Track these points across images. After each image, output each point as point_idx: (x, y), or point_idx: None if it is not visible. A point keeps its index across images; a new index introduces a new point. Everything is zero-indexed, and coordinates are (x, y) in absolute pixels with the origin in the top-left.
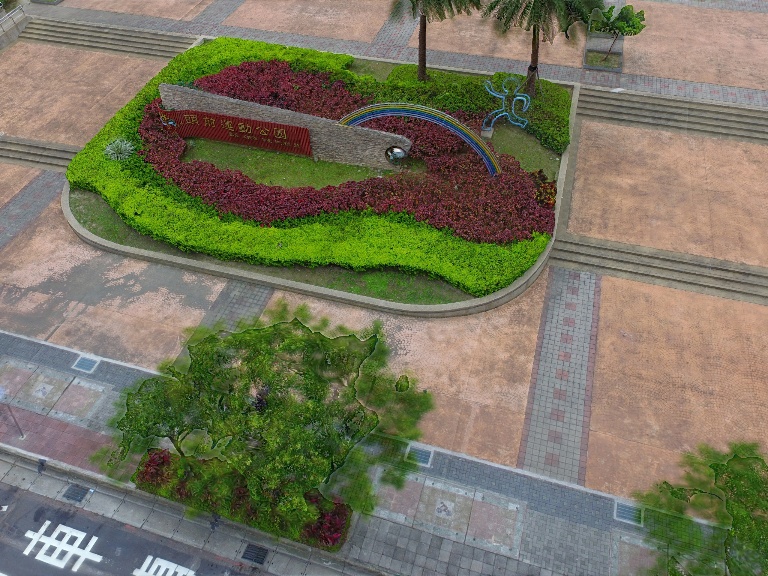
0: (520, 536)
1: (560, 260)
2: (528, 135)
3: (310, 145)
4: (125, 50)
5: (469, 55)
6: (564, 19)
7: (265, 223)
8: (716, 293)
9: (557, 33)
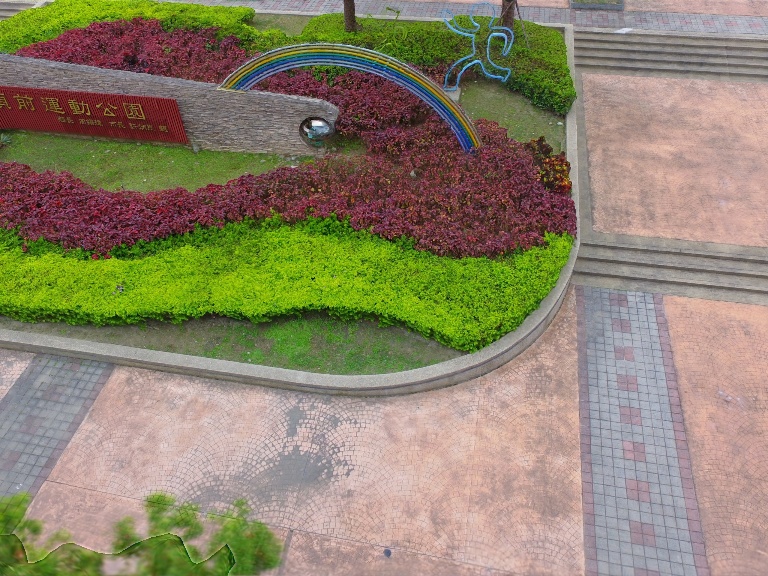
0: None
1: (590, 275)
2: (511, 94)
3: (183, 127)
4: None
5: (415, 2)
6: None
7: (99, 252)
8: None
9: None
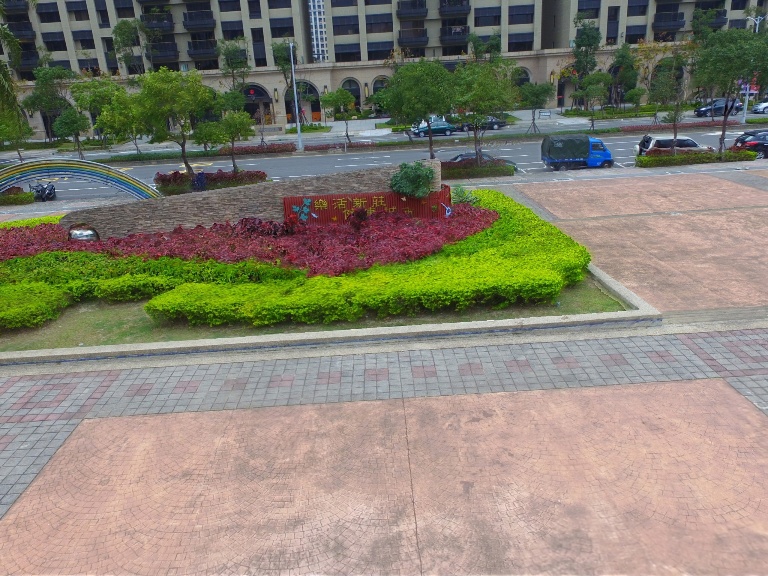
0: (68, 204)
1: None
2: None
3: None
4: None
5: None
6: None
7: None
8: None
9: None
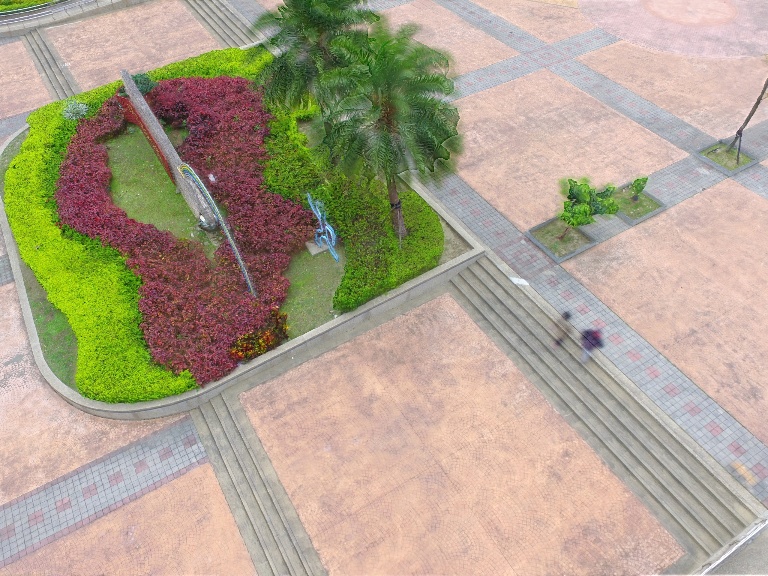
0: None
1: (203, 416)
2: None
3: (173, 175)
4: (216, 30)
5: None
6: (345, 163)
7: (59, 223)
8: (265, 575)
9: (360, 176)
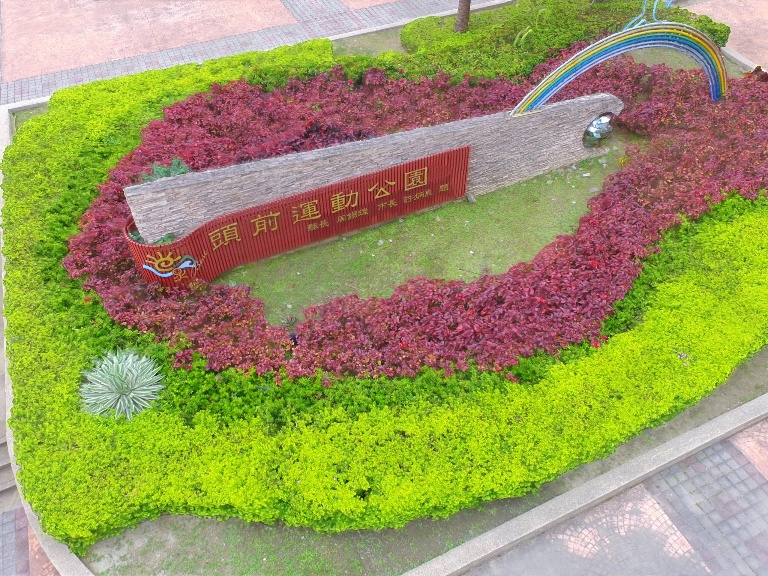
0: None
1: None
2: None
3: (464, 177)
4: None
5: None
6: None
7: (598, 337)
8: None
9: None
